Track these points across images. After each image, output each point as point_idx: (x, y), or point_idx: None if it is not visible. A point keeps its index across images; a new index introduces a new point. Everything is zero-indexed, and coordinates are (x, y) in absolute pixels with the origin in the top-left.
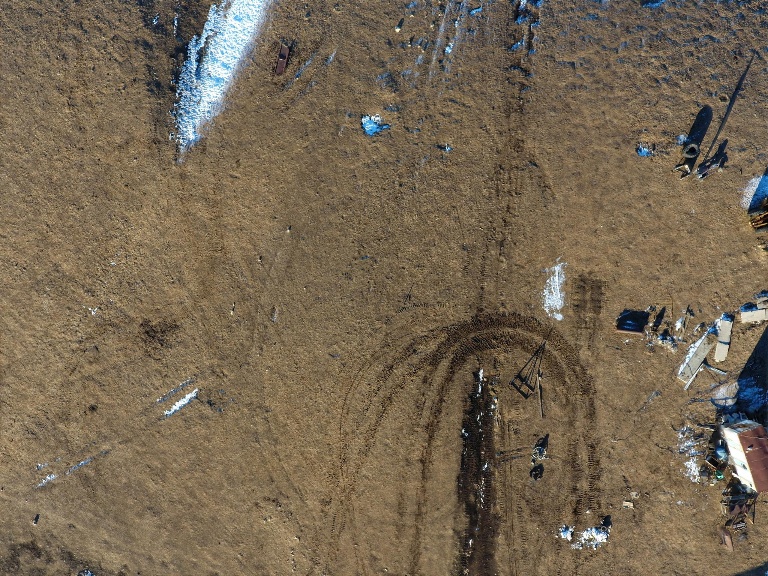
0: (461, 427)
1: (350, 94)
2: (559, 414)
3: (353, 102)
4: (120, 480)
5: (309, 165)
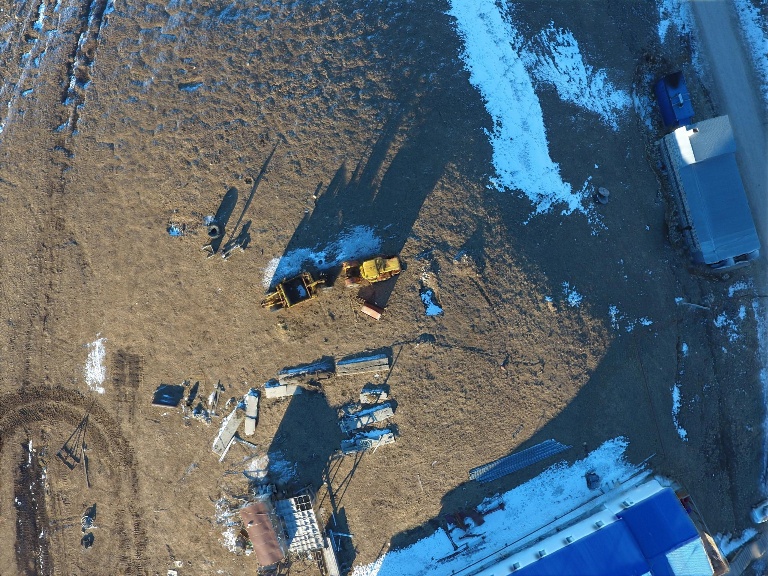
0: (13, 496)
1: None
2: (105, 484)
3: None
4: None
5: None
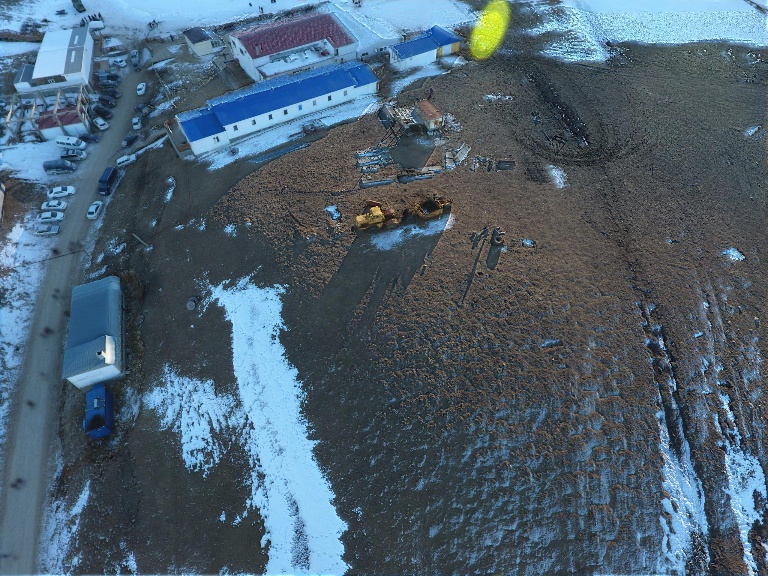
0: None
1: (765, 273)
2: (533, 132)
3: (759, 268)
4: (763, 105)
5: (765, 231)
